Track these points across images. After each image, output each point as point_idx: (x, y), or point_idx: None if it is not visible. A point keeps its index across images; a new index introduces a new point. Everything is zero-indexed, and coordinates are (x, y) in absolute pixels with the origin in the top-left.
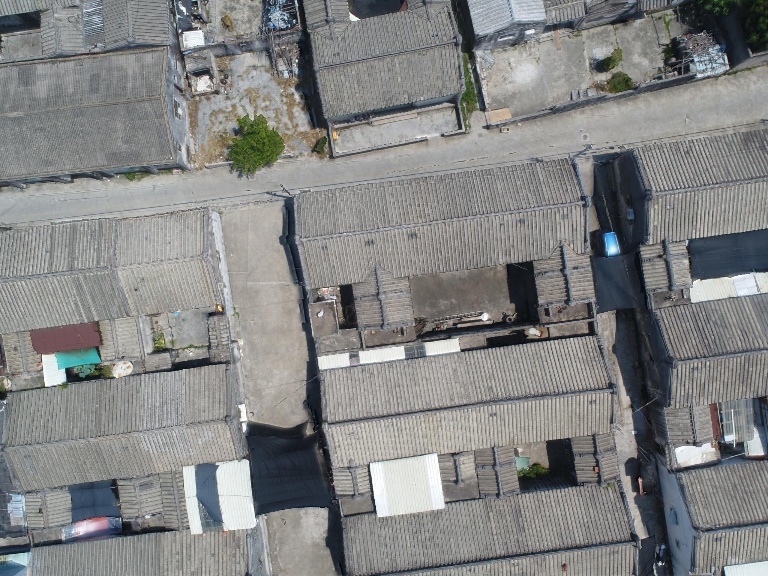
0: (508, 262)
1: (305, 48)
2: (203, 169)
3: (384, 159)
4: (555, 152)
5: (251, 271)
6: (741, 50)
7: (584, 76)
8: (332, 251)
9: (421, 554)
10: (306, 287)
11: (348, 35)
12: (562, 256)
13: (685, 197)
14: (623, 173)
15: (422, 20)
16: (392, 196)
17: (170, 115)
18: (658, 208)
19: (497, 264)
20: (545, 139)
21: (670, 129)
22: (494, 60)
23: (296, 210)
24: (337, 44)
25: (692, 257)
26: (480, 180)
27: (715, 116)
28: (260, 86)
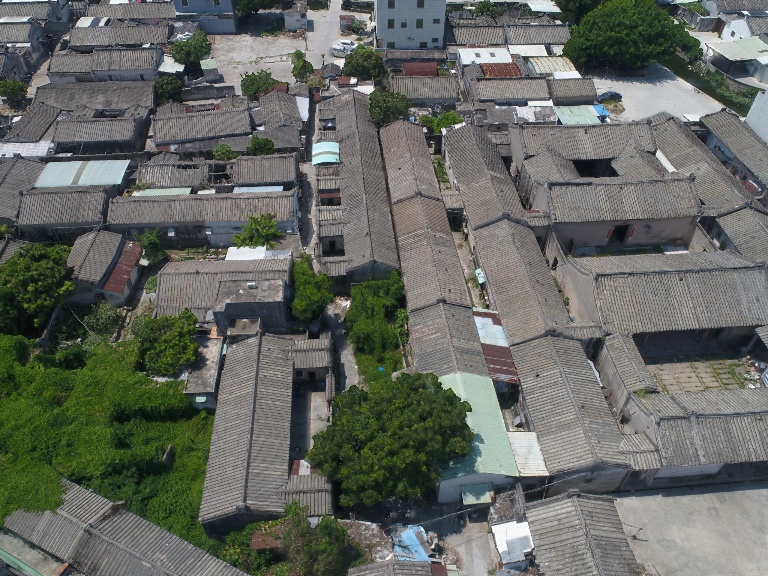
0: None
1: None
2: None
3: None
4: None
5: None
6: None
7: None
8: None
9: (21, 8)
10: (16, 53)
11: None
12: None
13: None
14: None
15: None
16: None
17: None
18: None
19: None
20: None
21: None
22: None
23: None
24: None
25: None
26: None
27: None
28: None
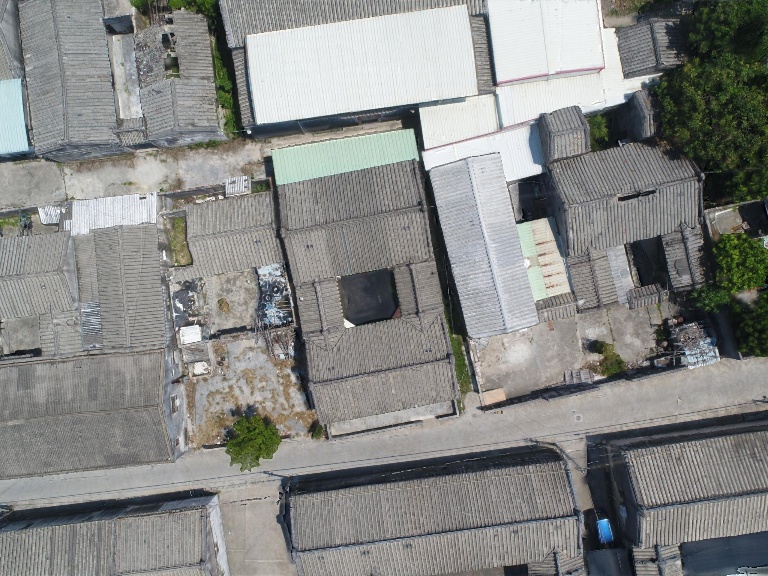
0: (502, 565)
1: (301, 331)
2: (201, 449)
3: (380, 439)
4: (549, 432)
5: (249, 549)
6: (732, 348)
7: (577, 356)
8: (328, 560)
9: None
10: None
11: (343, 346)
12: (556, 563)
13: (677, 510)
14: (616, 465)
15: (416, 331)
16: (387, 502)
17: (168, 420)
18: (650, 520)
19: (491, 567)
20: (539, 420)
21: (662, 410)
22: (488, 341)
23: (292, 517)
24: (332, 356)
25: (684, 559)
26: (474, 485)
27: (707, 397)
28: (257, 367)
